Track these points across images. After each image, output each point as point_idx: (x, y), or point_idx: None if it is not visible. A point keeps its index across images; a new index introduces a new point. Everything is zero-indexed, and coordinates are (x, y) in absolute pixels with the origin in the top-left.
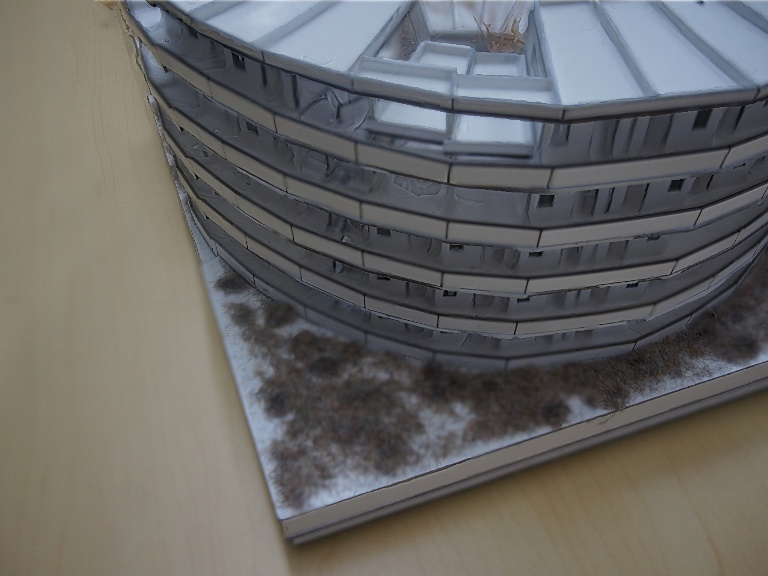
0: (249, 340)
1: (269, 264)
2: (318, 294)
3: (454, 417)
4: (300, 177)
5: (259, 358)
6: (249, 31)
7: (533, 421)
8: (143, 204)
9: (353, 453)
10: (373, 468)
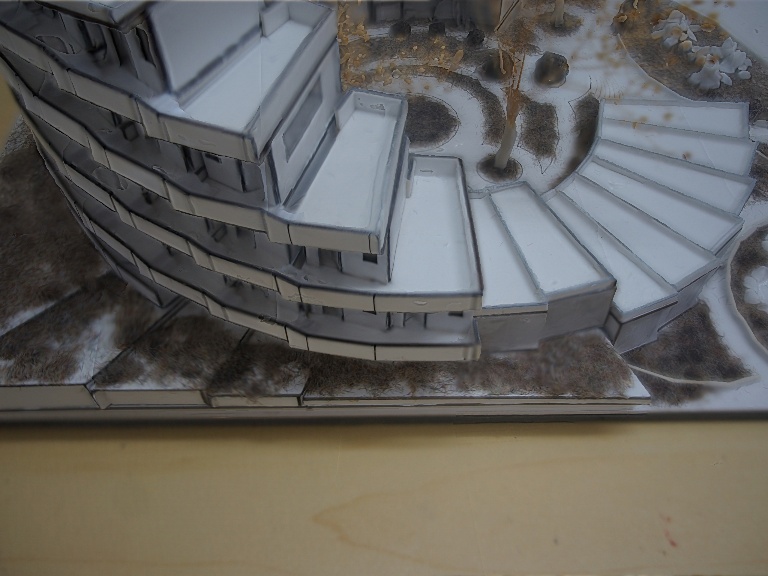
0: None
1: None
2: None
3: None
4: None
5: None
6: None
7: None
8: None
9: None
10: None
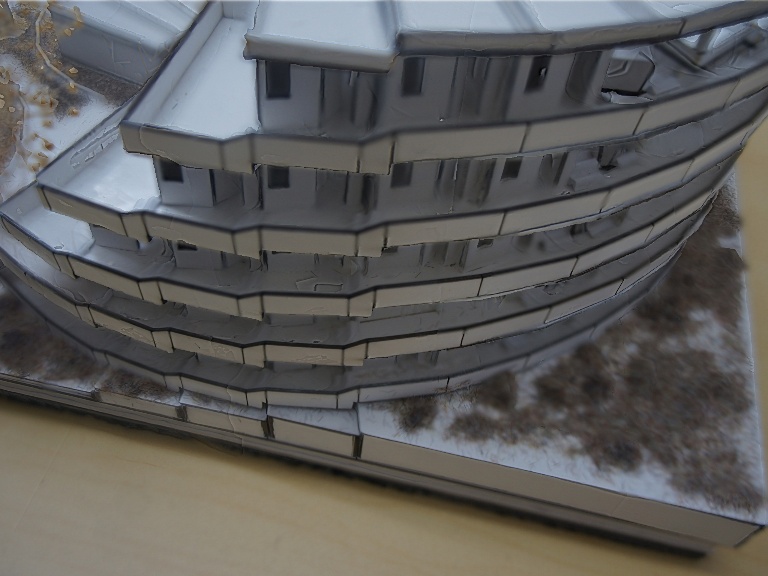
0: (517, 438)
1: (495, 340)
2: (508, 338)
3: (705, 325)
4: (621, 181)
5: (548, 442)
6: (589, 18)
7: (735, 277)
8: (63, 478)
9: (714, 421)
10: (738, 414)
